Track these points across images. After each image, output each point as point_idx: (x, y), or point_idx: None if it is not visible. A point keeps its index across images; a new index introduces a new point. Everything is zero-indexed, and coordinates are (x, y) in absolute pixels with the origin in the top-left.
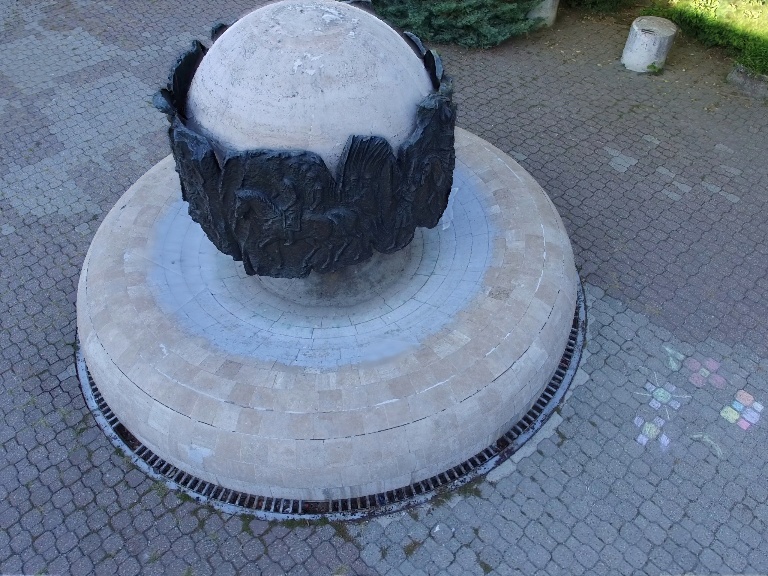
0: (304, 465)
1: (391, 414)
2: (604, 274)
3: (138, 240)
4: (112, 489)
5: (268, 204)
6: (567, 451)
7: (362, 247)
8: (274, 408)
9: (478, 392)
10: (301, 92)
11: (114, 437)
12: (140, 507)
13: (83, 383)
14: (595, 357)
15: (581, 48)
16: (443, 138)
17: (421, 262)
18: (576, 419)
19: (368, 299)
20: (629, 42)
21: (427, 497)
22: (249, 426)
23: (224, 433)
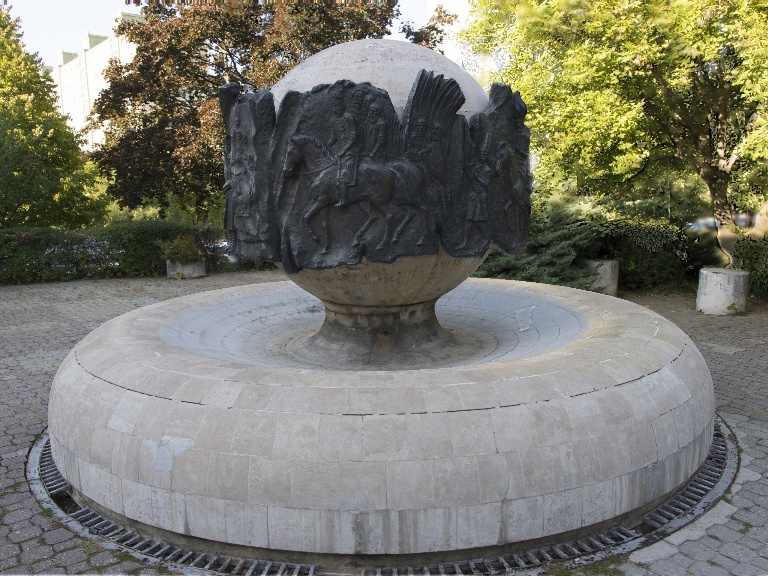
0: (328, 454)
1: (466, 394)
2: (741, 406)
3: (158, 315)
4: (16, 544)
5: (323, 150)
6: (759, 537)
7: (427, 228)
8: (294, 384)
9: (595, 391)
10: (370, 59)
11: (47, 501)
12: (50, 563)
13: (31, 461)
14: (761, 460)
15: (650, 306)
16: (518, 137)
17: (496, 349)
18: (759, 509)
19: (429, 366)
20: (701, 287)
21: (529, 573)
22: (254, 400)
23: (215, 411)
